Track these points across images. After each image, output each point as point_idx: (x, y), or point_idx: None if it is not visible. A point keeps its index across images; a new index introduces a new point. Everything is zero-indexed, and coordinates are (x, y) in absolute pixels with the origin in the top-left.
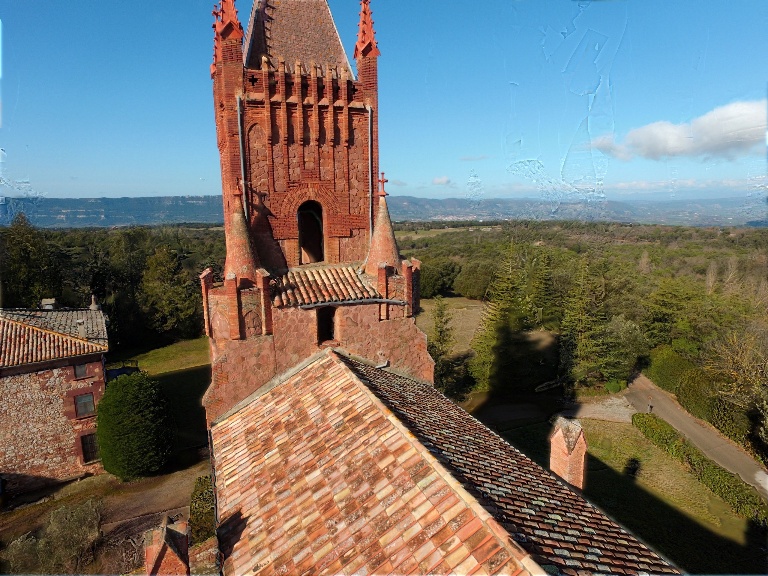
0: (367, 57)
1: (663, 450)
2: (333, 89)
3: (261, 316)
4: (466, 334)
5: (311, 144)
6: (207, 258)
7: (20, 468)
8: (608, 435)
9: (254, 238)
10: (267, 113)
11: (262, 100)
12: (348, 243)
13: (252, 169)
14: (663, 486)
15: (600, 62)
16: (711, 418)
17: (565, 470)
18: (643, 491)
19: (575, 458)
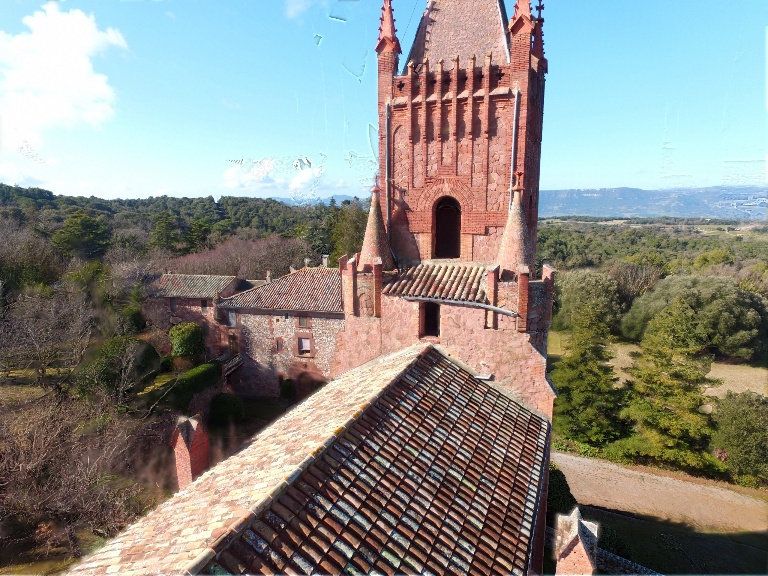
0: (518, 34)
1: None
2: (475, 79)
3: (373, 299)
4: None
5: (450, 139)
6: (545, 251)
7: None
8: None
9: (394, 230)
10: (409, 114)
11: (405, 103)
12: (483, 241)
13: (396, 167)
14: None
15: None
16: None
17: None
18: None
19: (570, 571)
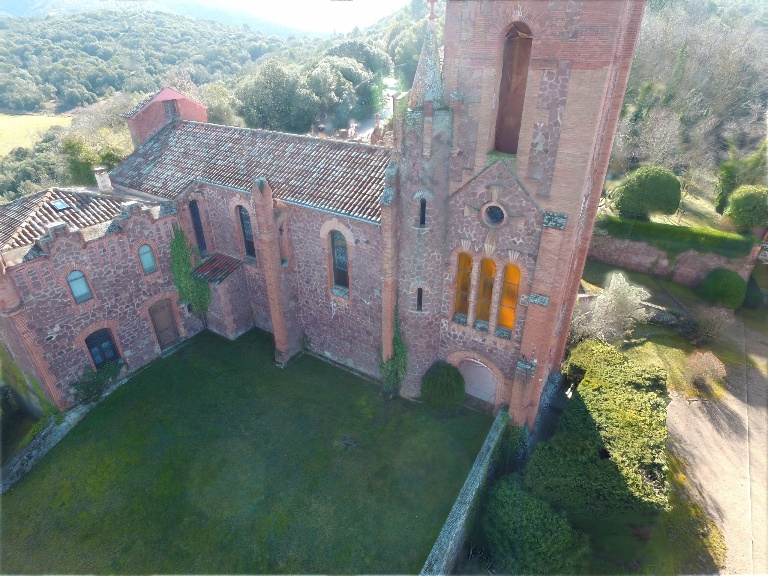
0: None
1: None
2: None
3: None
4: None
5: None
6: None
7: None
8: None
9: None
10: None
11: None
12: None
13: None
14: None
15: None
16: None
17: None
18: None
19: None
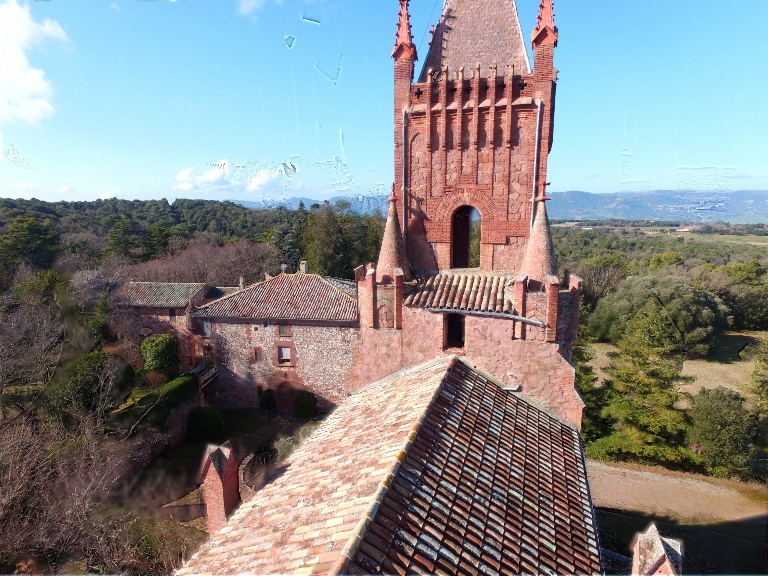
0: (541, 45)
1: None
2: (497, 88)
3: (394, 311)
4: None
5: (470, 148)
6: None
7: (325, 394)
8: None
9: (410, 239)
10: (427, 122)
11: (424, 111)
12: (504, 251)
13: (413, 176)
14: None
15: None
16: None
17: None
18: None
19: None
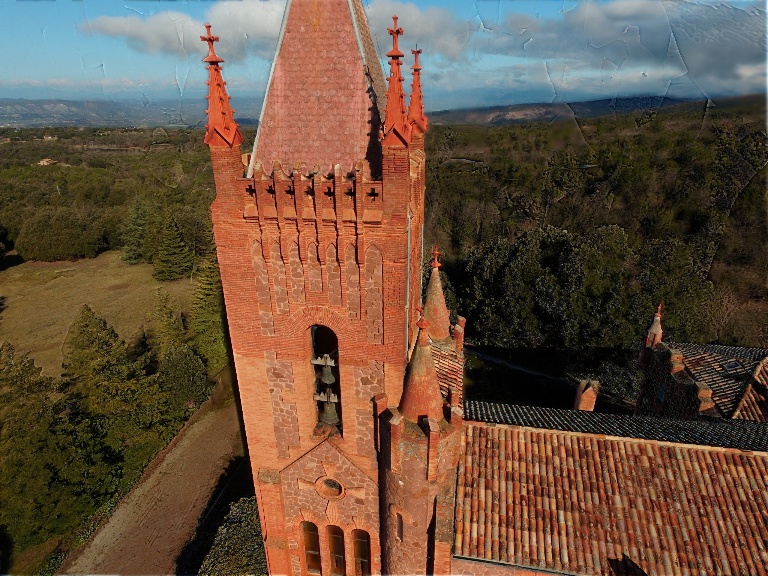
0: None
1: None
2: None
3: None
4: (112, 311)
5: None
6: None
7: None
8: None
9: None
10: (415, 224)
11: None
12: None
13: None
14: None
15: (231, 6)
16: None
17: (592, 406)
18: None
19: None
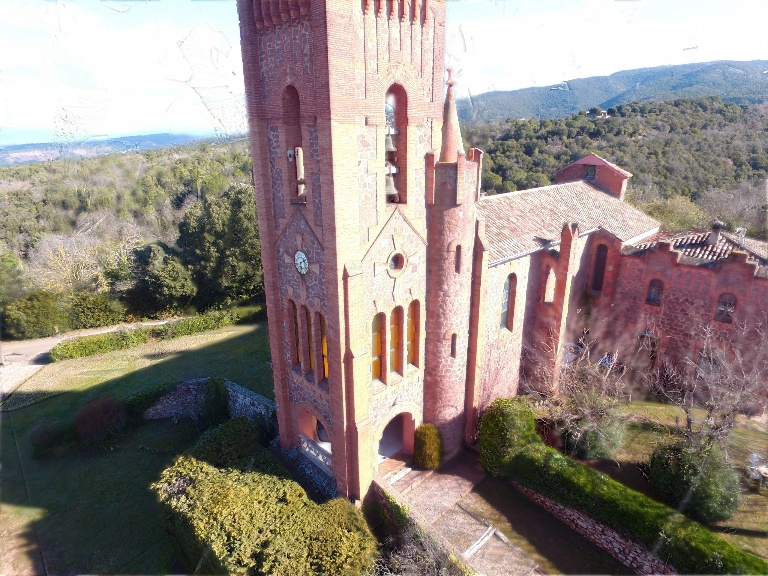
0: None
1: (120, 348)
2: None
3: None
4: None
5: None
6: None
7: None
8: (72, 373)
9: None
10: None
11: None
12: None
13: None
14: (187, 345)
15: None
16: (79, 324)
17: None
18: (200, 348)
19: None
